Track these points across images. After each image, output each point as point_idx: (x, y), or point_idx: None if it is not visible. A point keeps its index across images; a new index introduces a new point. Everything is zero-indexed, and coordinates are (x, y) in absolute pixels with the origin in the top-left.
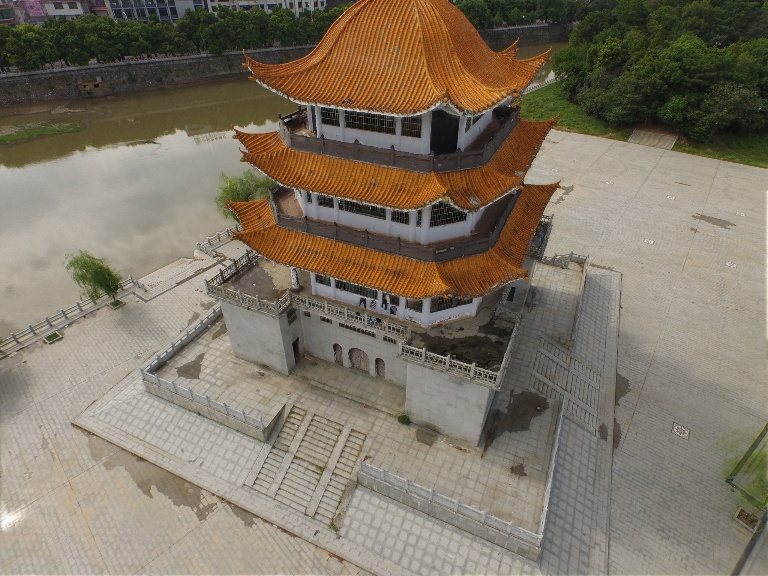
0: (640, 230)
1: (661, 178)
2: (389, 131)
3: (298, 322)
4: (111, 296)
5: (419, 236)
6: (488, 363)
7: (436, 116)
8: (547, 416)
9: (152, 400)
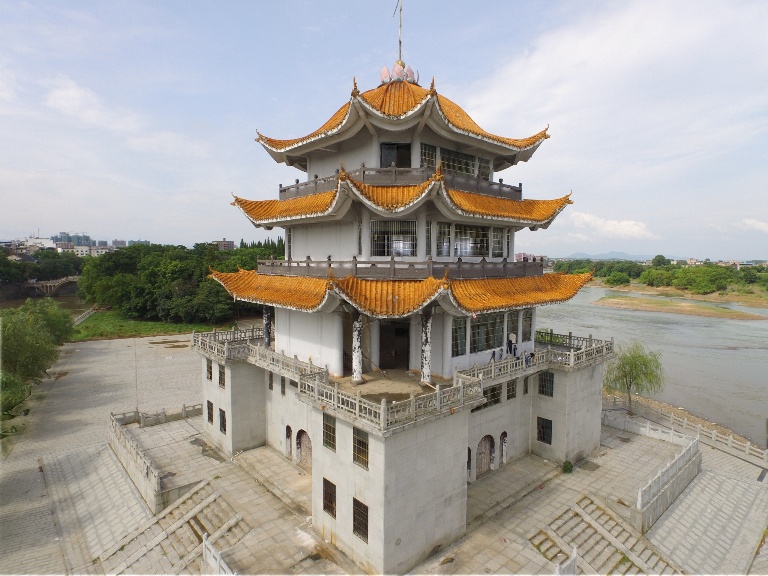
0: None
1: None
2: None
3: None
4: None
5: None
6: None
7: None
8: None
9: None
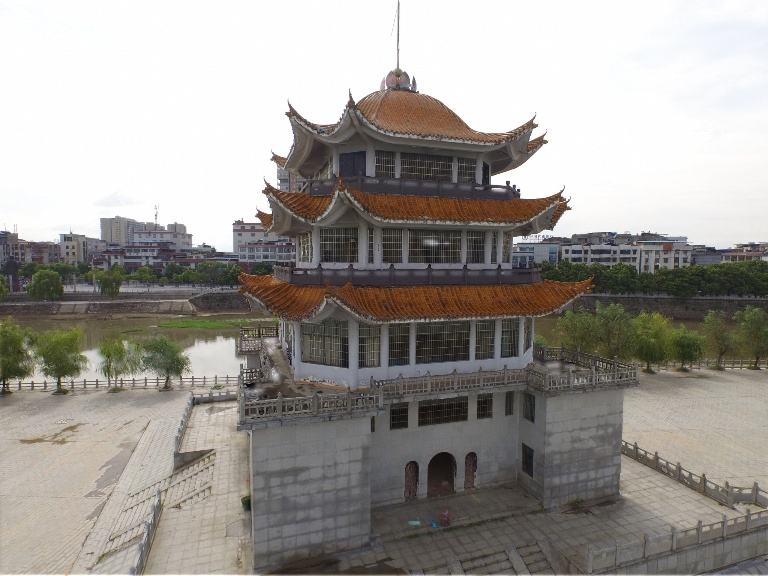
0: None
1: None
2: None
3: None
4: None
5: None
6: None
7: (344, 159)
8: None
9: None
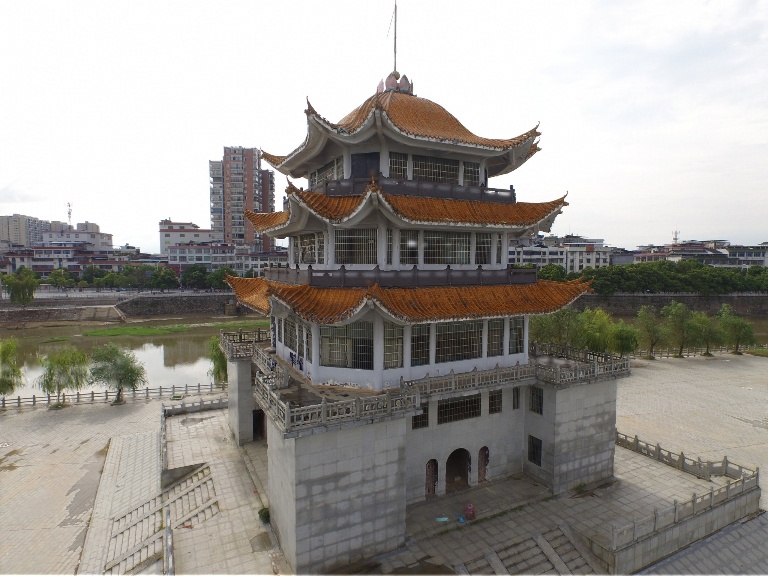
0: None
1: None
2: None
3: None
4: None
5: None
6: None
7: (356, 159)
8: None
9: (156, 437)
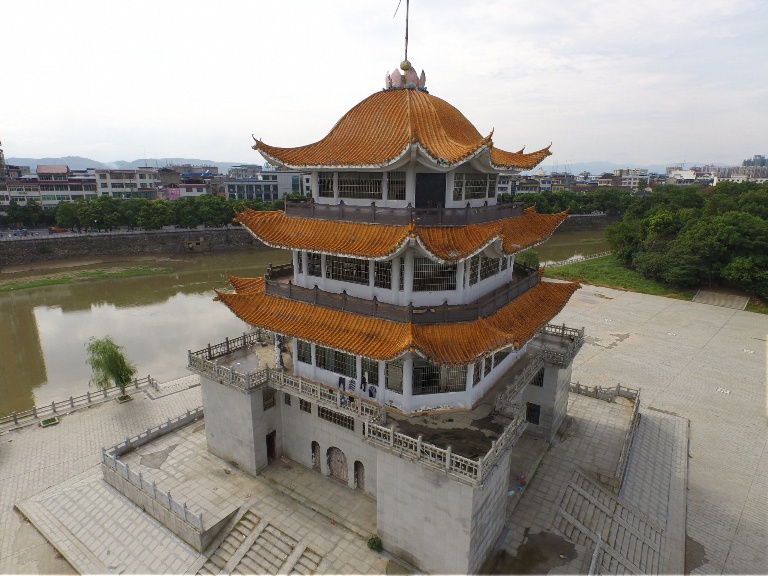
0: (711, 379)
1: (734, 333)
2: (377, 197)
3: (277, 411)
4: None
5: (402, 302)
6: (474, 457)
7: (420, 179)
8: (573, 568)
9: (104, 489)
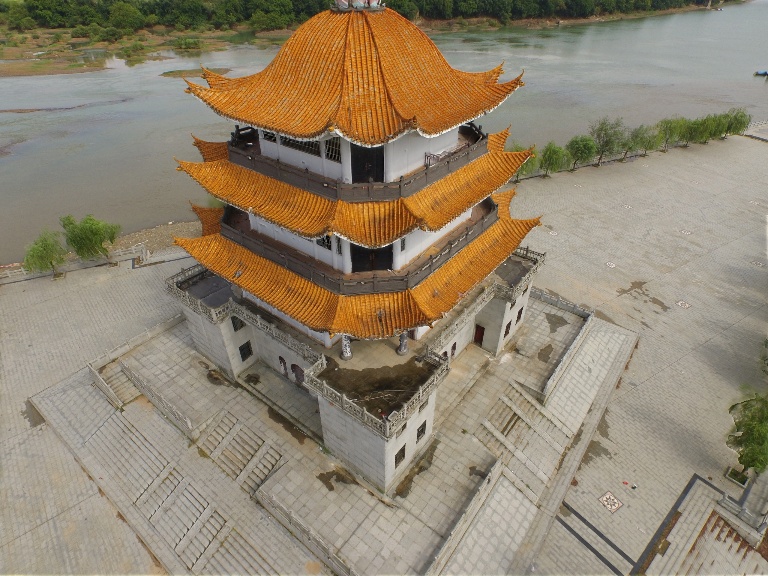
0: None
1: None
2: None
3: None
4: (766, 501)
5: None
6: None
7: None
8: None
9: None
